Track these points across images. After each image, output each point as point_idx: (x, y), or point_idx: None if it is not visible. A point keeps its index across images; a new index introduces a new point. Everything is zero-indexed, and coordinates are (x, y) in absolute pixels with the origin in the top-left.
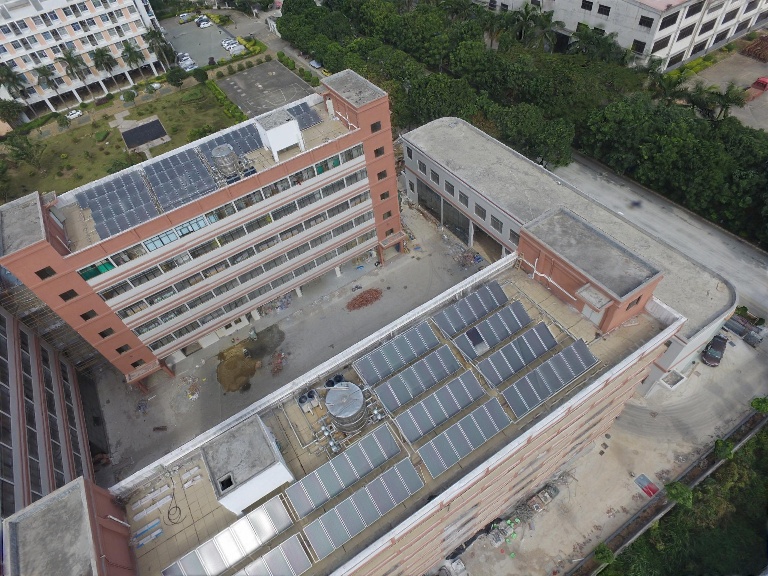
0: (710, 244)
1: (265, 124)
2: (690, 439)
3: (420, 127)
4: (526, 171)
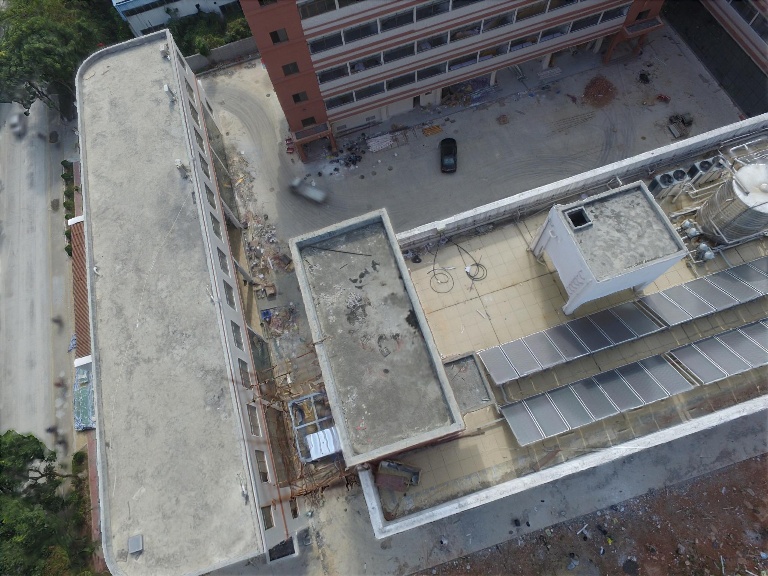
0: (5, 264)
1: (650, 223)
2: (212, 83)
3: (206, 571)
4: (115, 318)
